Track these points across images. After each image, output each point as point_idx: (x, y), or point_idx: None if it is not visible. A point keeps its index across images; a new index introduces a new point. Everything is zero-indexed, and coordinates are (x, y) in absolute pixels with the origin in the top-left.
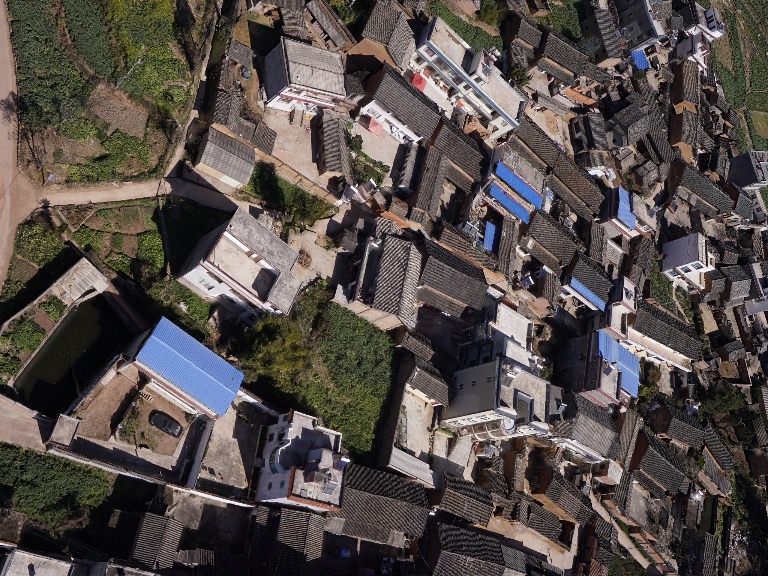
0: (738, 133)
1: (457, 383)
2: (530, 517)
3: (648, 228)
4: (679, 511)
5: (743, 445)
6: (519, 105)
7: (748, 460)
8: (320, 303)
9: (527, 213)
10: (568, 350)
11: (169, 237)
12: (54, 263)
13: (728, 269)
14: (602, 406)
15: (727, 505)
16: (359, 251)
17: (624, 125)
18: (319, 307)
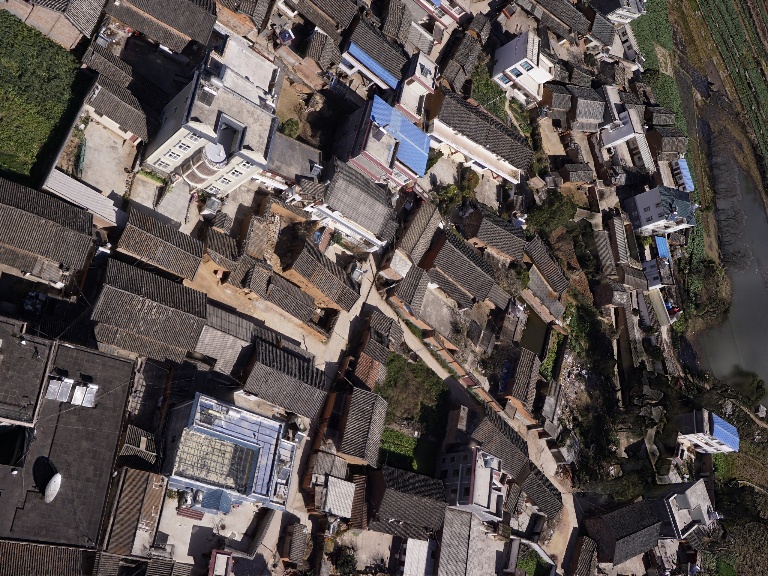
0: None
1: (163, 117)
2: (269, 289)
3: (461, 11)
4: (496, 328)
5: (586, 274)
6: None
7: (593, 291)
8: None
9: None
10: (346, 125)
11: None
12: None
13: (576, 88)
14: (376, 180)
15: (563, 334)
16: None
17: None
18: None
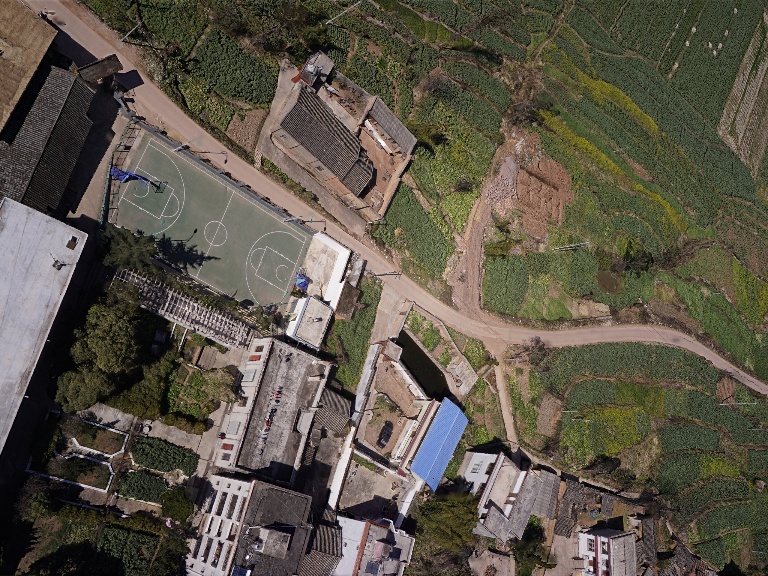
0: None
1: None
2: None
3: None
4: None
5: None
6: None
7: None
8: None
9: None
10: None
11: (487, 449)
12: None
13: None
14: None
15: None
16: None
17: None
18: None
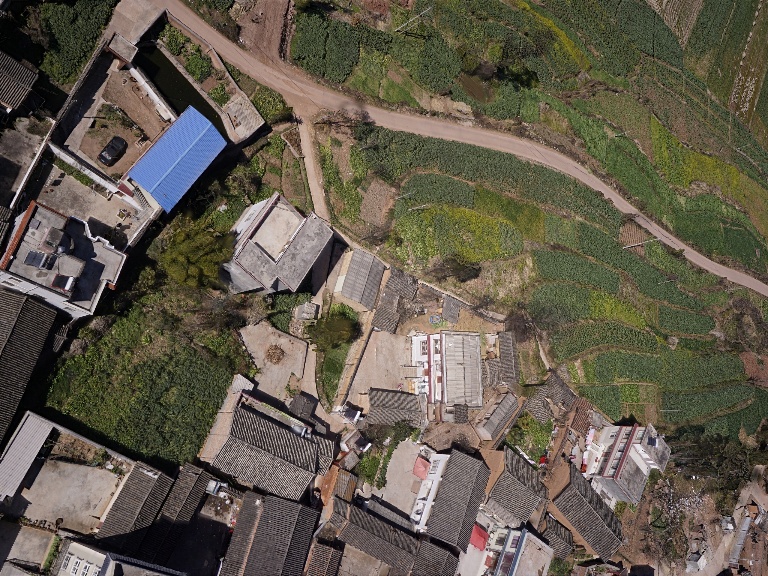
0: None
1: None
2: None
3: None
4: None
5: None
6: None
7: None
8: None
9: None
10: None
11: None
12: None
13: None
14: None
15: None
16: None
17: None
18: None
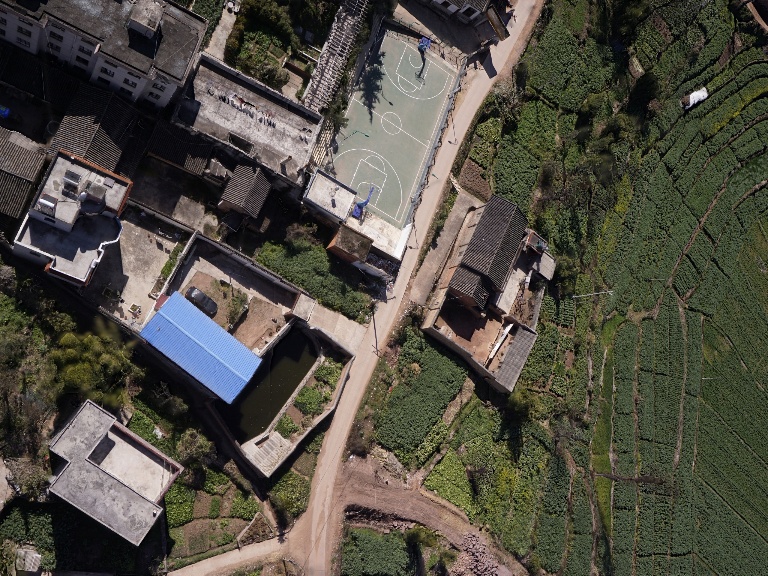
0: None
1: None
2: None
3: None
4: None
5: None
6: None
7: None
8: None
9: None
10: None
11: (159, 521)
12: (281, 474)
13: None
14: None
15: None
16: None
17: None
18: None
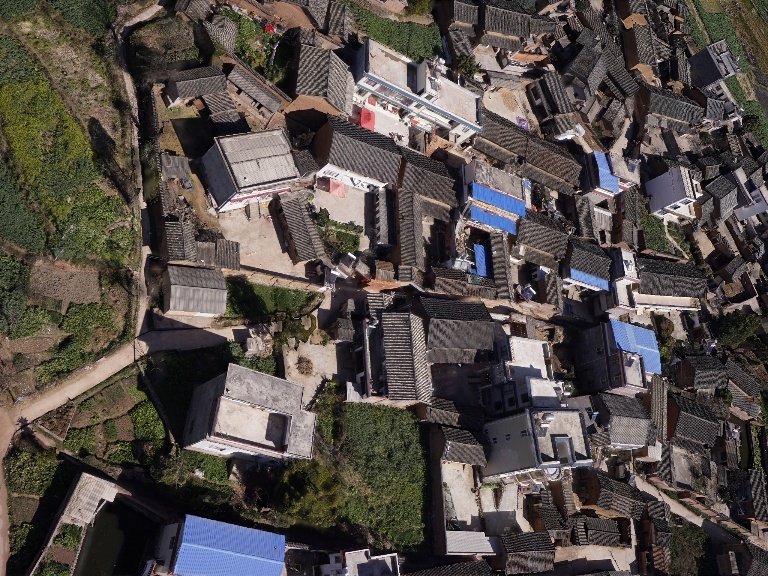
0: (688, 20)
1: (489, 437)
2: (588, 535)
3: (631, 183)
4: (718, 454)
5: (762, 360)
6: (475, 103)
7: None
8: (334, 409)
9: (512, 223)
10: (583, 344)
11: (161, 402)
12: (53, 486)
13: (713, 185)
14: None
15: (759, 426)
16: (358, 337)
17: (583, 76)
18: (334, 414)
